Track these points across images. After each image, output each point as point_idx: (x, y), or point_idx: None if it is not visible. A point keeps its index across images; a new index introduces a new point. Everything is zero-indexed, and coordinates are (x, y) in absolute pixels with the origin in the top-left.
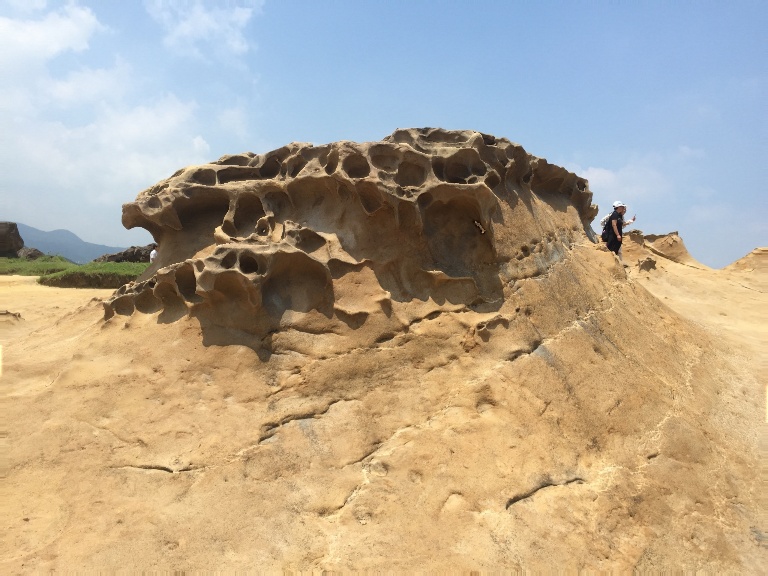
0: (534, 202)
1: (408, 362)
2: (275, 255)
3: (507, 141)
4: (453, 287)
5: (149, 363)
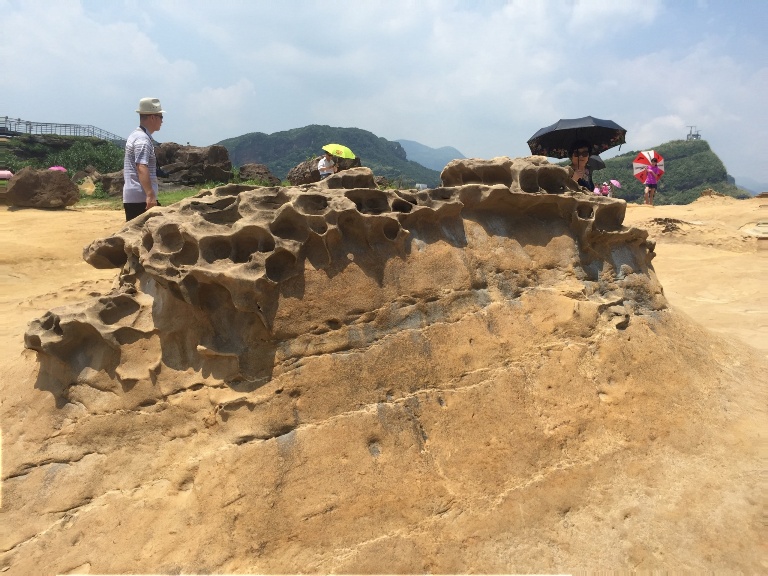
0: (403, 259)
1: (159, 428)
2: (70, 324)
3: (330, 206)
4: (220, 362)
5: (2, 395)
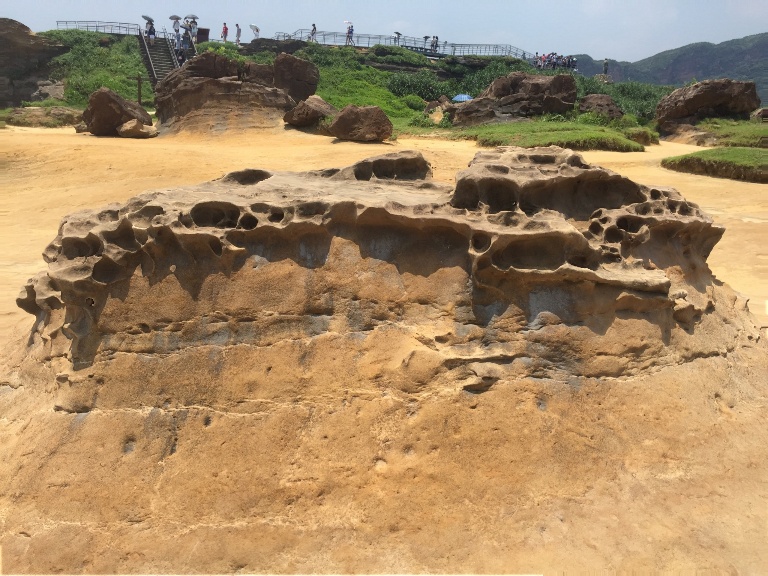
0: (228, 275)
1: None
2: (31, 287)
3: None
4: None
5: (27, 326)
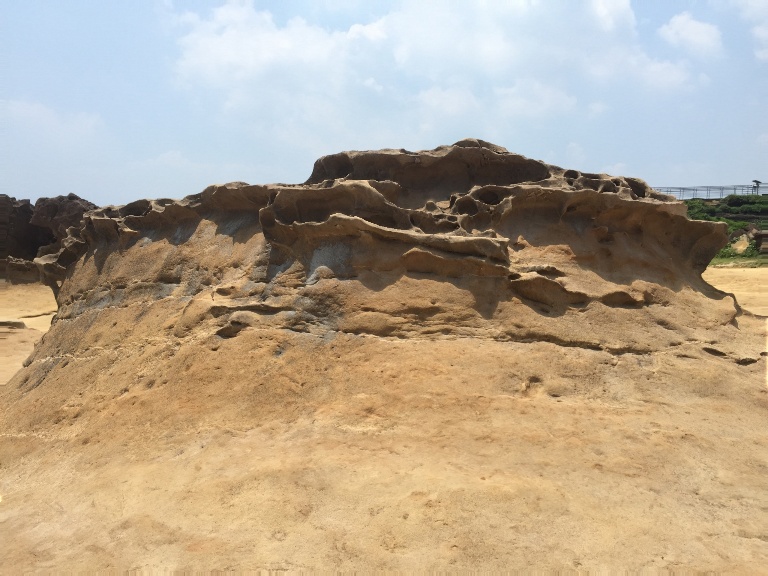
0: (121, 253)
1: None
2: None
3: None
4: None
5: None
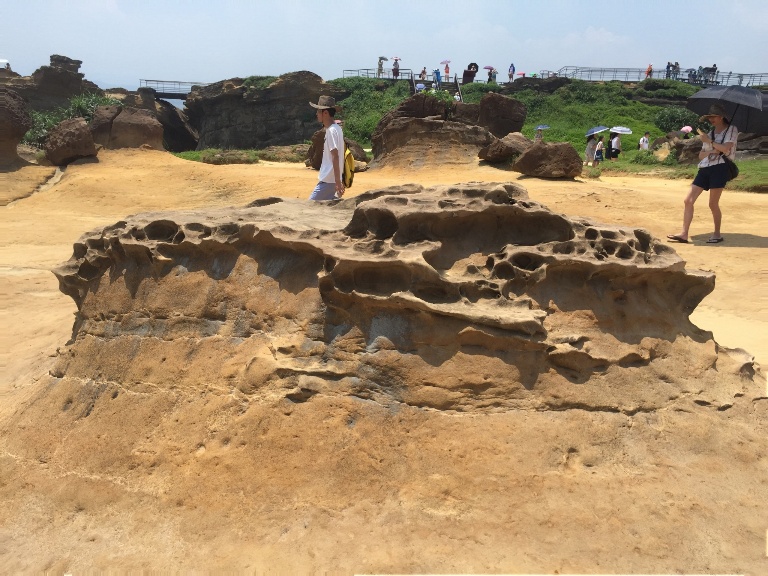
0: (156, 280)
1: None
2: None
3: None
4: None
5: None
